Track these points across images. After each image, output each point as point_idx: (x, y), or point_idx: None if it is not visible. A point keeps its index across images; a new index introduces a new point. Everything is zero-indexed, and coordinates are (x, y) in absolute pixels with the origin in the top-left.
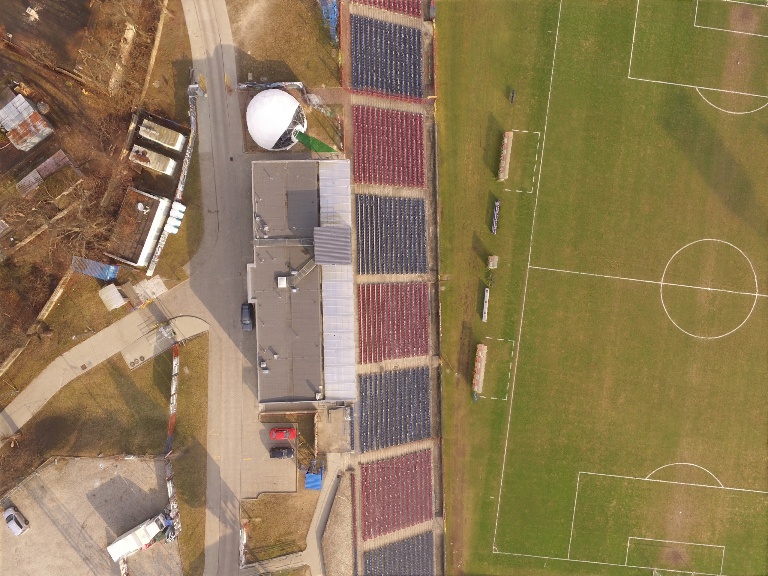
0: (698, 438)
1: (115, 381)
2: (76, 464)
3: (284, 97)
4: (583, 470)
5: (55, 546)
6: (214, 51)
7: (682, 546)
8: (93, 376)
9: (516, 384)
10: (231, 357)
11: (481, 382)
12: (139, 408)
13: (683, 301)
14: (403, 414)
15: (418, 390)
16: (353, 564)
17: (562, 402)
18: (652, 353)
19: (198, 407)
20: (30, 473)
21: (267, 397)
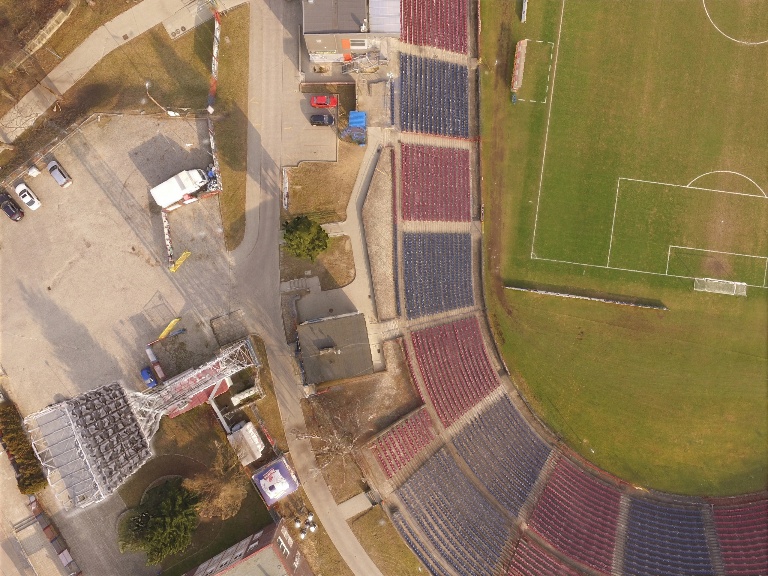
0: (741, 145)
1: (156, 51)
2: (118, 122)
3: None
4: (623, 176)
5: (97, 204)
6: None
7: (724, 256)
8: (135, 46)
9: (555, 87)
10: (272, 28)
11: (521, 76)
12: (180, 77)
13: (725, 5)
14: (442, 106)
15: (457, 86)
16: (393, 242)
17: (602, 106)
18: (694, 58)
19: (239, 75)
20: (73, 130)
21: (312, 30)
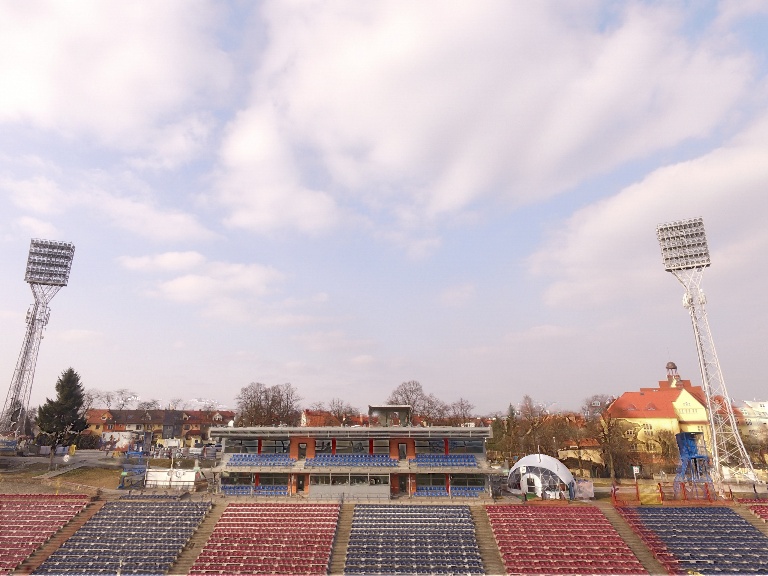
0: None
1: None
2: None
3: (561, 465)
4: None
5: None
6: (599, 490)
7: None
8: None
9: None
10: None
11: None
12: None
13: None
14: None
15: (125, 573)
16: None
17: None
18: None
19: None
20: None
21: None
